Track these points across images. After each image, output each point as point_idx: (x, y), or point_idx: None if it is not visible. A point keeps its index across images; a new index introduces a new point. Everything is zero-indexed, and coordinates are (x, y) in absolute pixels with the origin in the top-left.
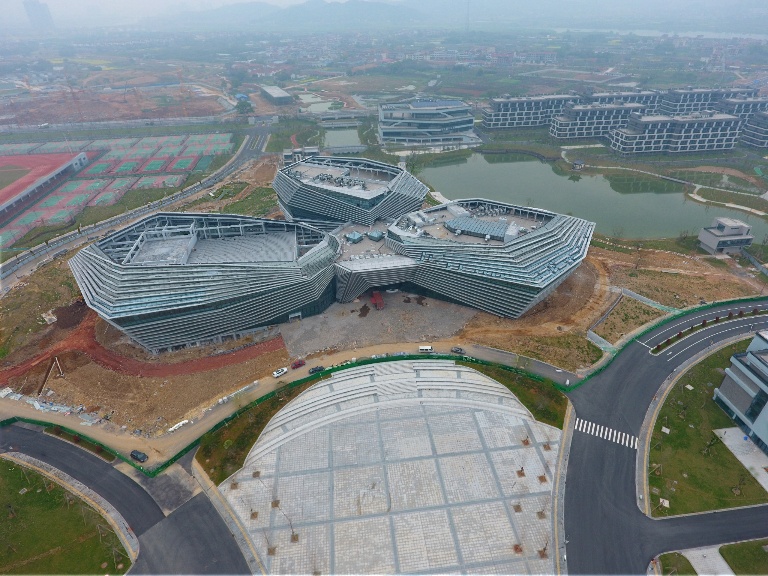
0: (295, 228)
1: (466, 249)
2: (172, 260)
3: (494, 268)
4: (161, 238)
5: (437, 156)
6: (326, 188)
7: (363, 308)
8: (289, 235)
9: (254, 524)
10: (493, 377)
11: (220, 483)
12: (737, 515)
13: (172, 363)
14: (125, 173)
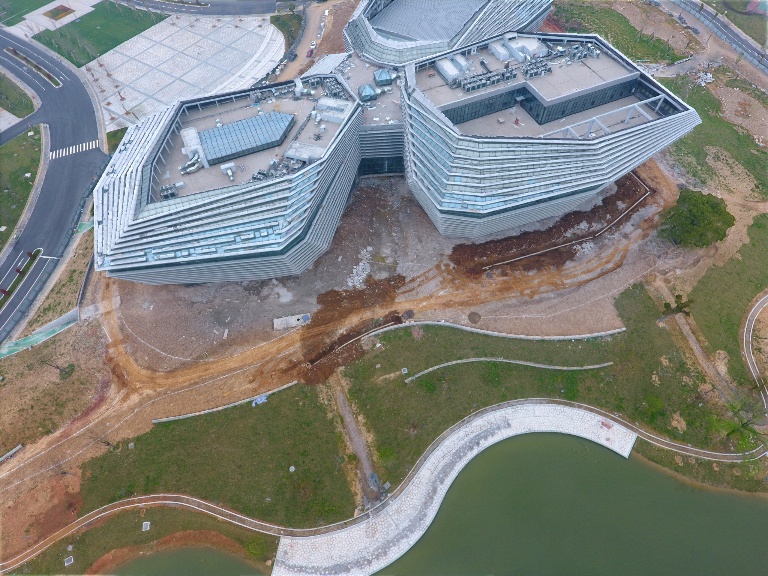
0: None
1: None
2: None
3: None
4: None
5: None
6: None
7: None
8: None
9: (237, 20)
10: None
11: None
12: None
13: None
14: None
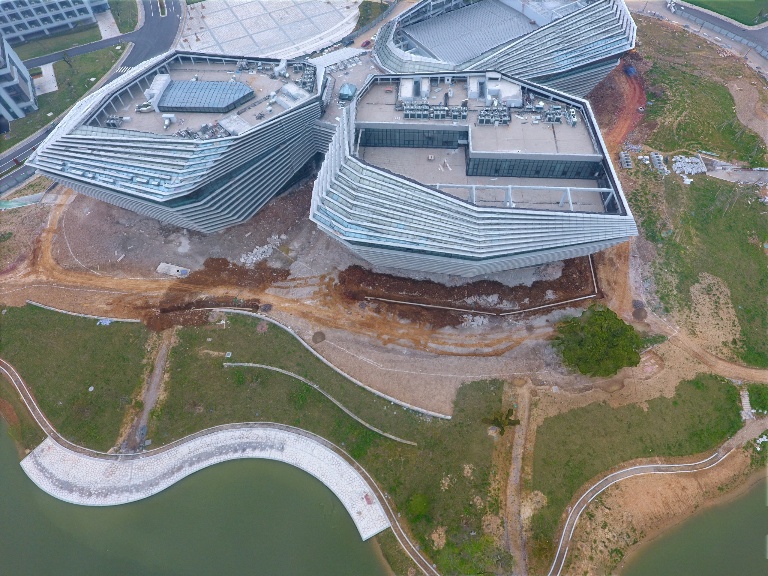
0: None
1: None
2: None
3: None
4: None
5: None
6: None
7: None
8: None
9: None
10: None
11: None
12: (80, 53)
13: None
14: None
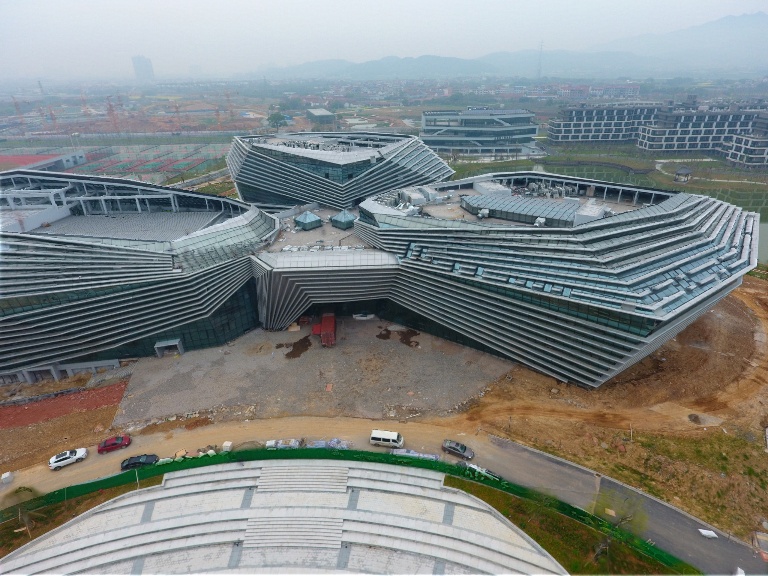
0: (222, 206)
1: (492, 236)
2: None
3: (549, 274)
4: (8, 206)
5: (486, 166)
6: (282, 150)
7: (300, 342)
8: (207, 215)
9: None
10: (533, 533)
11: None
12: None
13: None
14: (111, 170)
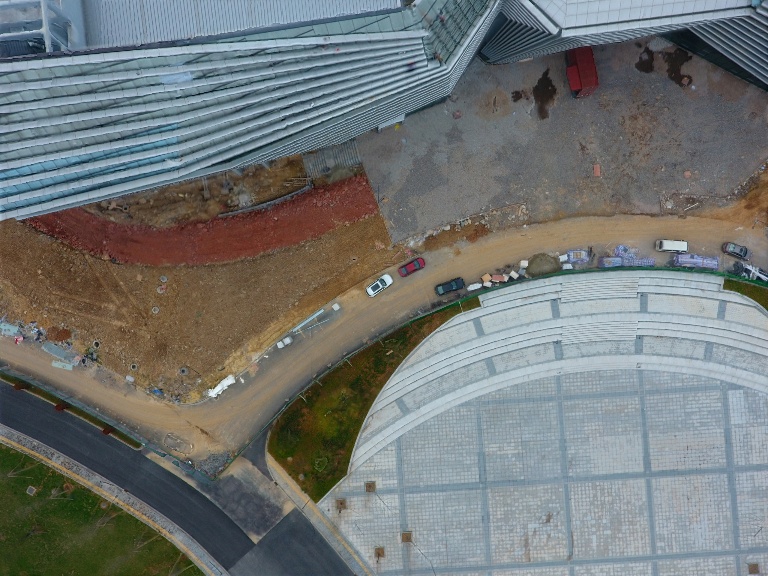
0: None
1: None
2: (31, 2)
3: None
4: None
5: None
6: None
7: (541, 87)
8: None
9: (382, 564)
10: None
11: (319, 500)
12: None
13: (158, 227)
14: None
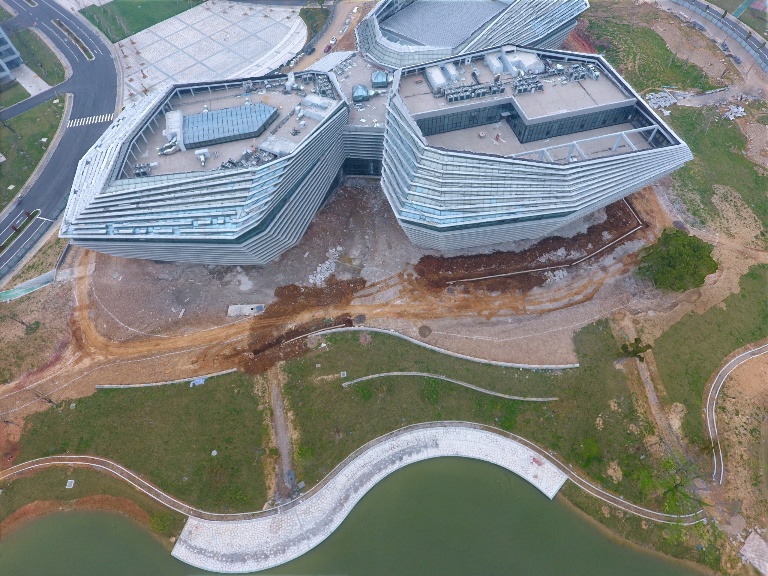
0: None
1: None
2: None
3: None
4: None
5: None
6: None
7: None
8: None
9: None
10: None
11: None
12: (12, 115)
13: None
14: None
